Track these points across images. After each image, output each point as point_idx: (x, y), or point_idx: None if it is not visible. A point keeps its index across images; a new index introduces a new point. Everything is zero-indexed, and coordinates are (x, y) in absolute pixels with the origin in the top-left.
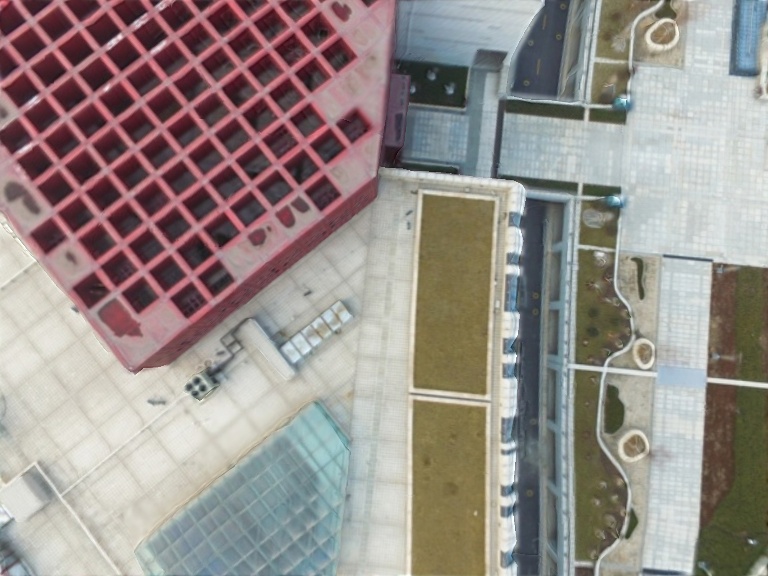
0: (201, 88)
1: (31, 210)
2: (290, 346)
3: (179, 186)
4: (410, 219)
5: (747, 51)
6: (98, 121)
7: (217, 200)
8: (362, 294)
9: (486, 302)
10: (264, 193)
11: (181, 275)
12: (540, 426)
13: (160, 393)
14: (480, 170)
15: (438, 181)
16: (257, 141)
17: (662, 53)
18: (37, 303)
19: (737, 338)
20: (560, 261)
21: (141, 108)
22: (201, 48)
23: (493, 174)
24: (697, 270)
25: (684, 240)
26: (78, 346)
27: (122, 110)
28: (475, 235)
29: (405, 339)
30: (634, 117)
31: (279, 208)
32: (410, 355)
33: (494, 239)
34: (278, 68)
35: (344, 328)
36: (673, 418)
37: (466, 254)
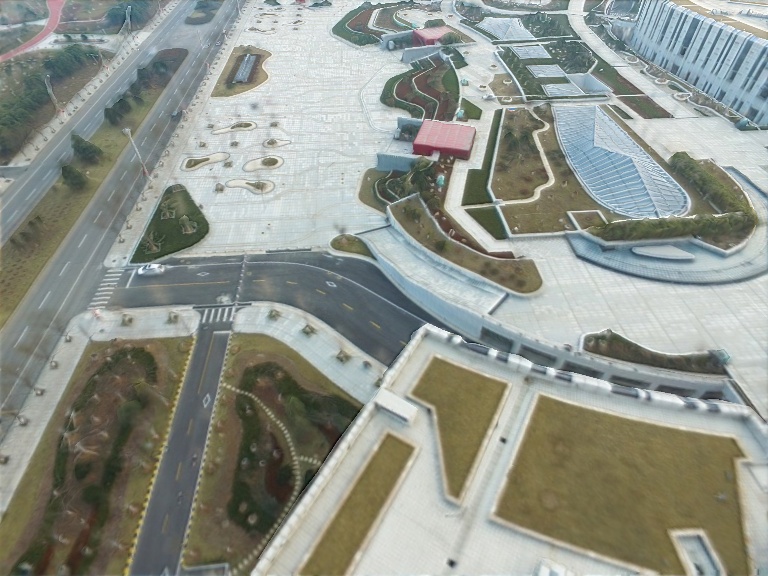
0: None
1: None
2: None
3: None
4: None
5: None
6: None
7: None
8: None
9: None
10: None
11: None
12: None
13: None
14: None
15: None
16: None
17: None
18: None
19: (646, 103)
20: None
21: None
22: None
23: None
24: None
25: None
26: None
27: None
28: None
29: None
30: (762, 149)
31: None
32: None
33: None
34: None
35: None
36: (651, 88)
37: None
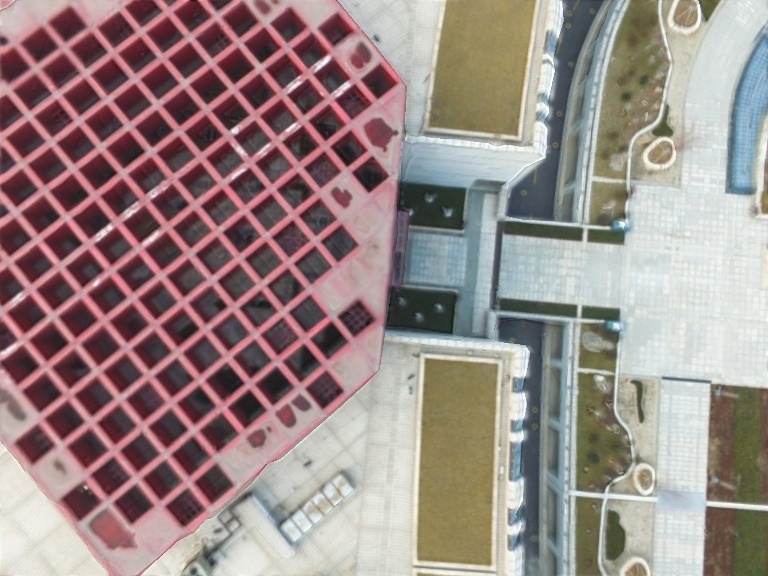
0: (196, 281)
1: (17, 416)
2: (290, 524)
3: (174, 385)
4: (412, 384)
5: (743, 169)
6: (87, 318)
7: (214, 400)
8: (364, 462)
9: (490, 469)
10: (263, 391)
11: (177, 481)
12: (540, 543)
13: (155, 573)
14: (479, 293)
15: (440, 346)
16: (255, 336)
17: (659, 172)
18: (23, 481)
19: (735, 461)
20: (560, 382)
21: (133, 304)
22: (195, 238)
23: (492, 297)
24: (696, 392)
25: (683, 362)
26: (68, 526)
27: (113, 306)
28: (478, 400)
29: (408, 510)
30: (632, 237)
31: (279, 407)
32: (413, 526)
33: (498, 403)
34: (276, 258)
35: (345, 499)
36: (673, 543)
37: (469, 420)
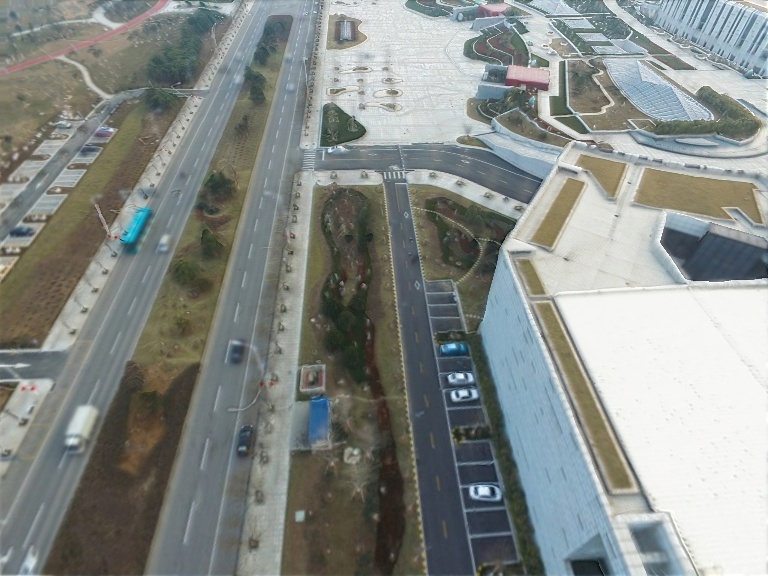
0: None
1: None
2: None
3: None
4: None
5: None
6: None
7: None
8: None
9: None
10: None
11: None
12: None
13: None
14: None
15: None
16: None
17: None
18: None
19: None
20: None
21: None
22: None
23: None
24: None
25: None
26: None
27: None
28: None
29: None
30: None
31: None
32: None
33: None
34: None
35: None
36: None
37: None
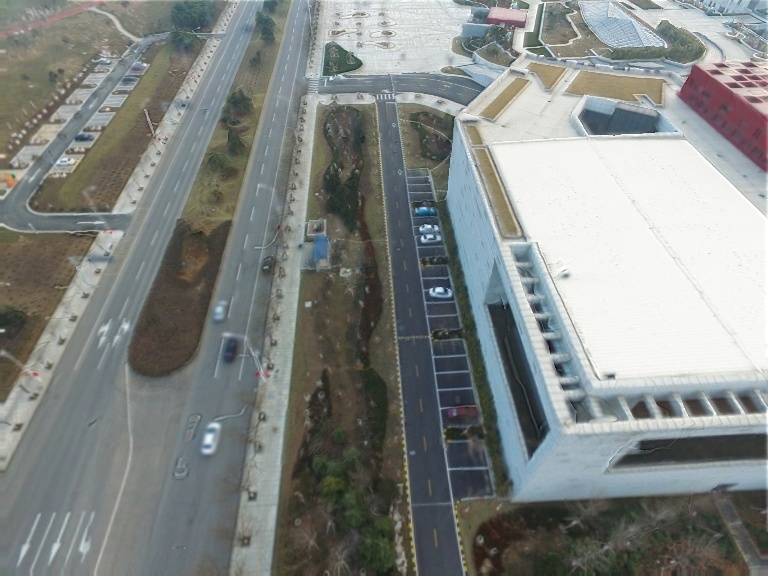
0: None
1: None
2: None
3: None
4: None
5: None
6: None
7: None
8: None
9: None
10: None
11: None
12: None
13: None
14: None
15: None
16: None
17: None
18: None
19: (645, 1)
20: None
21: None
22: None
23: (752, 15)
24: None
25: None
26: None
27: None
28: None
29: None
30: None
31: None
32: None
33: None
34: None
35: None
36: None
37: None
